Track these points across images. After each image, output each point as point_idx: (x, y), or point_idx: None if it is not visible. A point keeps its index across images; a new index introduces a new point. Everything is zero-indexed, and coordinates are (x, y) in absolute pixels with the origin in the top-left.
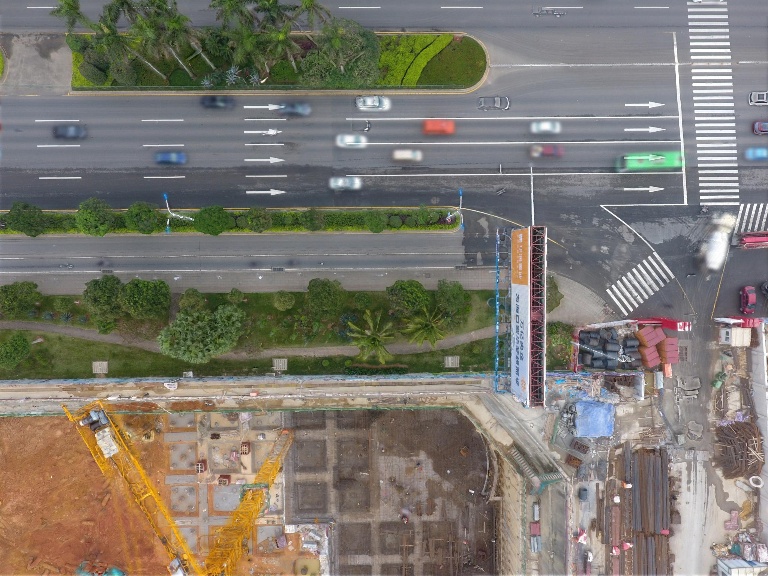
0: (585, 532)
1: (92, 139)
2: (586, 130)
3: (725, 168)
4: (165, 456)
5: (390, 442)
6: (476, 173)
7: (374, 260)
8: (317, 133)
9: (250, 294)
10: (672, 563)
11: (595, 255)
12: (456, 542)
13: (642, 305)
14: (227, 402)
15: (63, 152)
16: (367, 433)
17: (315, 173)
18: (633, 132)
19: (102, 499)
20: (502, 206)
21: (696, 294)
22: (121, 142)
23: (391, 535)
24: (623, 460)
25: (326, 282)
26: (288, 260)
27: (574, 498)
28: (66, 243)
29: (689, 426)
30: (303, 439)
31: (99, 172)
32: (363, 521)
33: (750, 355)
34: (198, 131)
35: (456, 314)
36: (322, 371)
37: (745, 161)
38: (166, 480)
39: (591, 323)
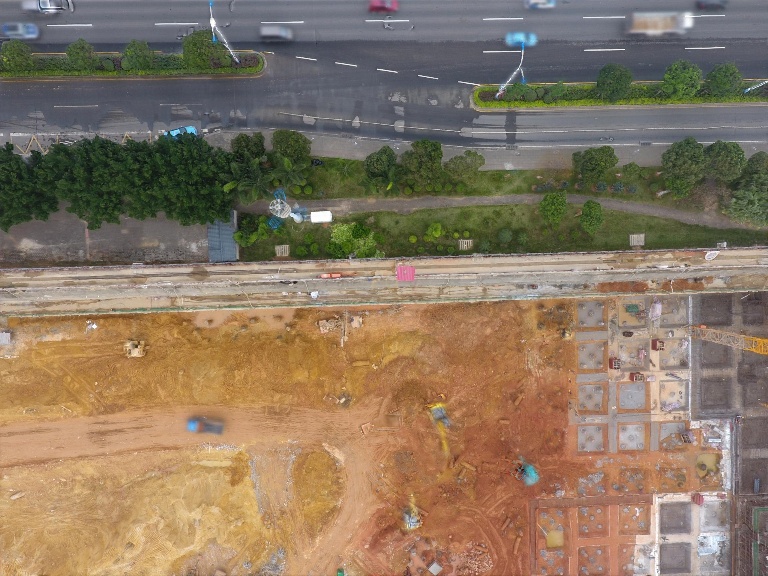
0: None
1: (636, 10)
2: None
3: None
4: (575, 355)
5: None
6: None
7: None
8: None
9: None
10: None
11: None
12: None
13: None
14: (715, 282)
15: (608, 24)
16: None
17: None
18: None
19: (514, 399)
20: None
21: None
22: (664, 13)
23: None
24: None
25: None
26: None
27: None
28: (608, 116)
29: None
30: None
31: (642, 43)
32: (766, 415)
33: None
34: (739, 1)
35: None
36: None
37: None
38: (577, 379)
39: None
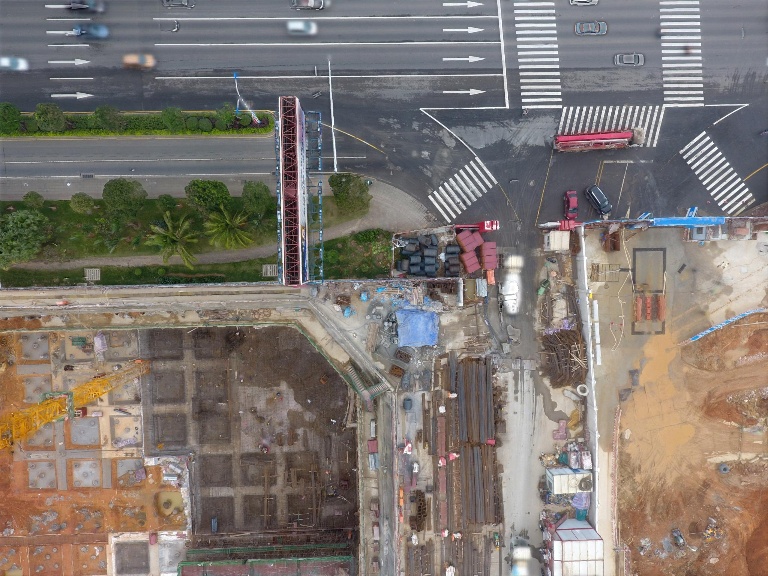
0: (410, 443)
1: None
2: (403, 31)
3: (546, 70)
4: (19, 389)
5: (250, 372)
6: (290, 75)
7: (187, 166)
8: (123, 33)
9: (58, 202)
10: (501, 474)
11: (416, 160)
12: (318, 472)
13: (465, 212)
14: (53, 320)
15: None
16: (225, 363)
17: (123, 75)
18: (451, 33)
19: None
20: (318, 110)
21: (519, 200)
22: None
23: (254, 467)
24: (448, 370)
25: (120, 181)
26: (97, 166)
27: (400, 409)
28: None
29: (508, 331)
30: (160, 370)
31: None
32: (224, 453)
33: (575, 262)
34: None
35: (265, 217)
36: (136, 281)
37: (567, 63)
38: None
39: (412, 230)
